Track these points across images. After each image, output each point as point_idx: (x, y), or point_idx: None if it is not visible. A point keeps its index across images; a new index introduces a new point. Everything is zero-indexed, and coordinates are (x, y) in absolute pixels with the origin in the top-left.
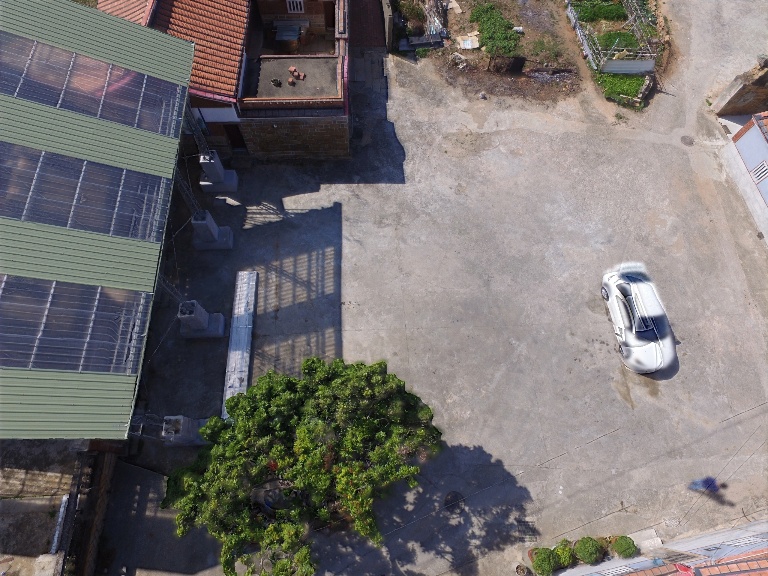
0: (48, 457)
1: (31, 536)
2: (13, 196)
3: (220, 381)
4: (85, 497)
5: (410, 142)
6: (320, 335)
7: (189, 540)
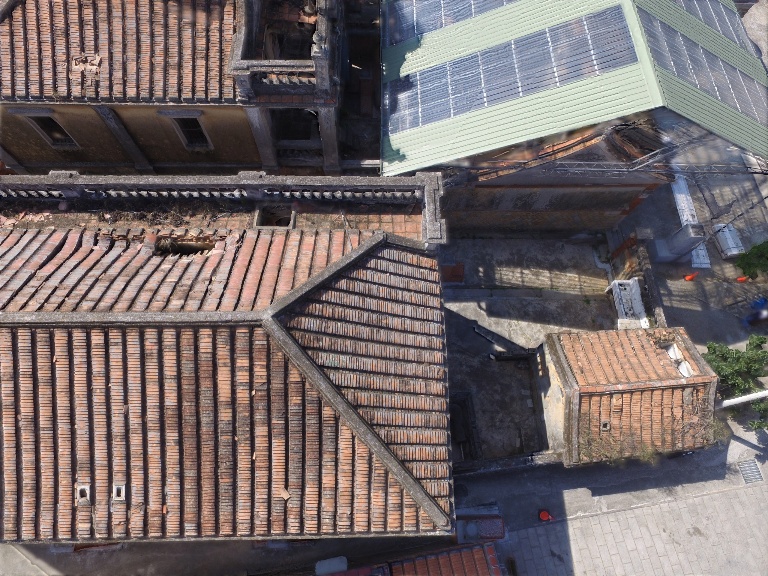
0: (562, 263)
1: (577, 316)
2: (692, 5)
3: (672, 217)
4: (643, 279)
5: (762, 41)
6: (741, 187)
7: (707, 325)
